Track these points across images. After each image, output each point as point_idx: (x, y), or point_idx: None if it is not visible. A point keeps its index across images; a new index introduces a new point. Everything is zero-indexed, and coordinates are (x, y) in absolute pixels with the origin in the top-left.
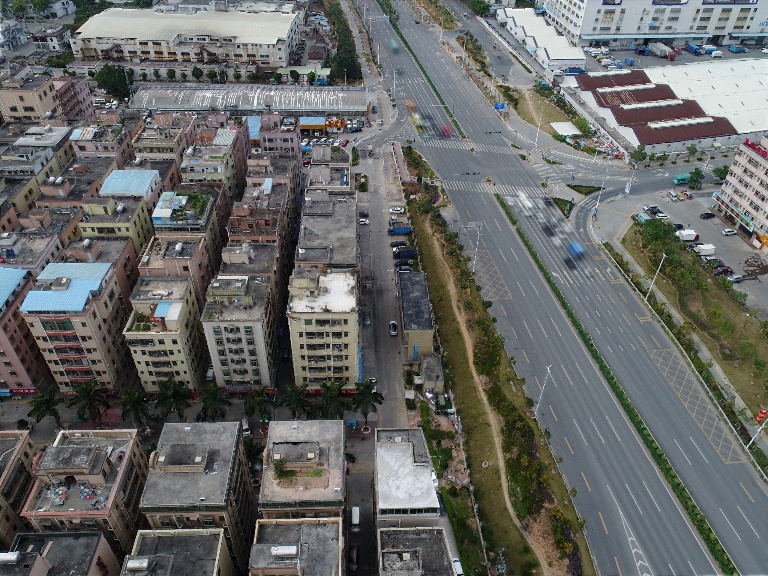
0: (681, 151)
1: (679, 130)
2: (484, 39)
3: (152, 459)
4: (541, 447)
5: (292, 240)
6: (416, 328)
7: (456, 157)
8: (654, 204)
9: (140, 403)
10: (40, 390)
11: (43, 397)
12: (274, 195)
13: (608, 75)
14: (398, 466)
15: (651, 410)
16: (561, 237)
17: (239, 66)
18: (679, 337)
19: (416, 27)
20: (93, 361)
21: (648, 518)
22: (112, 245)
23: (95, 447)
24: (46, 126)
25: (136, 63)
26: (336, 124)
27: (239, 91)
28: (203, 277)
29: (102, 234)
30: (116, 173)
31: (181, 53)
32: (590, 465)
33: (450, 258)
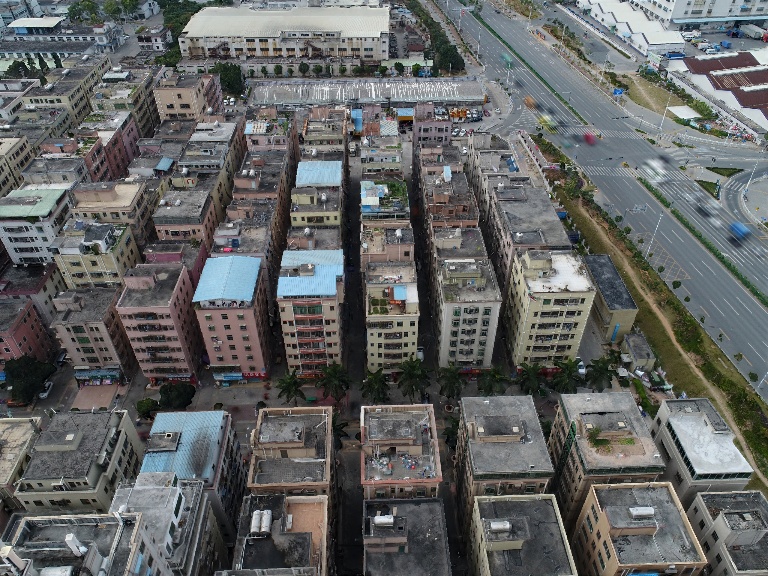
0: None
1: None
2: (571, 26)
3: (471, 430)
4: None
5: None
6: (620, 308)
7: (585, 143)
8: None
9: (383, 383)
10: (266, 374)
11: (292, 379)
12: (455, 182)
13: (716, 58)
14: (697, 434)
15: None
16: (718, 218)
17: (344, 60)
18: None
19: (498, 17)
20: (329, 344)
21: None
22: (324, 233)
23: (414, 420)
24: None
25: (243, 60)
26: (458, 114)
27: (354, 84)
28: None
29: (311, 223)
30: (303, 165)
31: (286, 49)
32: None
33: (617, 241)
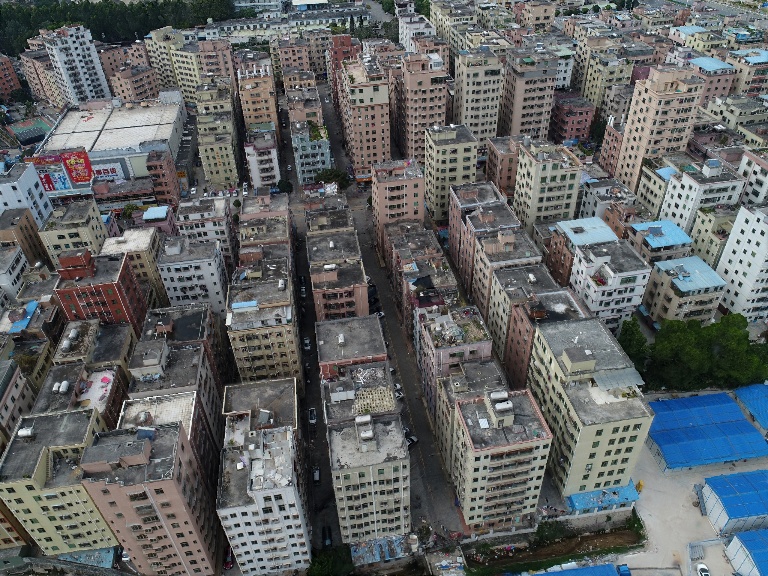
0: None
1: None
2: None
3: None
4: None
5: None
6: None
7: None
8: None
9: None
10: None
11: None
12: None
13: None
14: None
15: None
16: None
17: None
18: None
19: None
20: None
21: None
22: None
23: None
24: None
25: None
26: None
27: None
28: None
29: None
30: None
31: (514, 2)
32: None
33: None
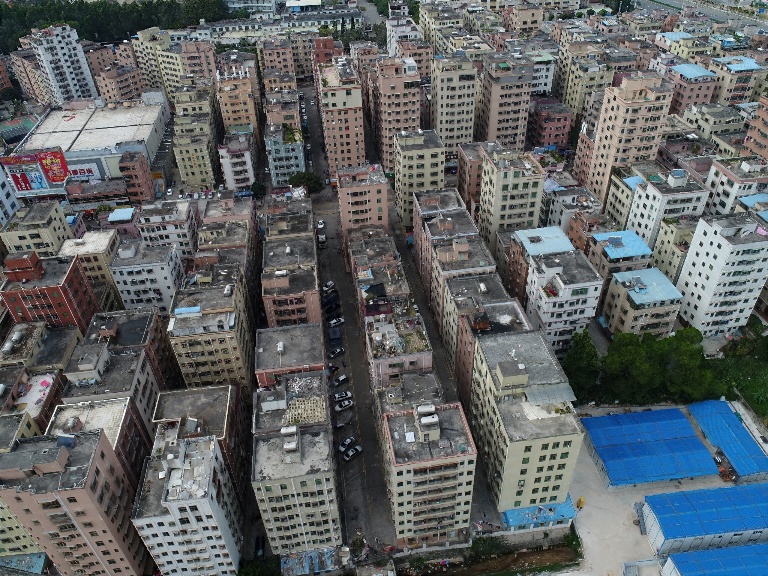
0: None
1: None
2: None
3: None
4: None
5: None
6: None
7: None
8: None
9: None
10: None
11: None
12: None
13: None
14: None
15: None
16: None
17: None
18: None
19: None
20: None
21: None
22: None
23: None
24: None
25: None
26: None
27: (578, 21)
28: None
29: None
30: None
31: None
32: None
33: None
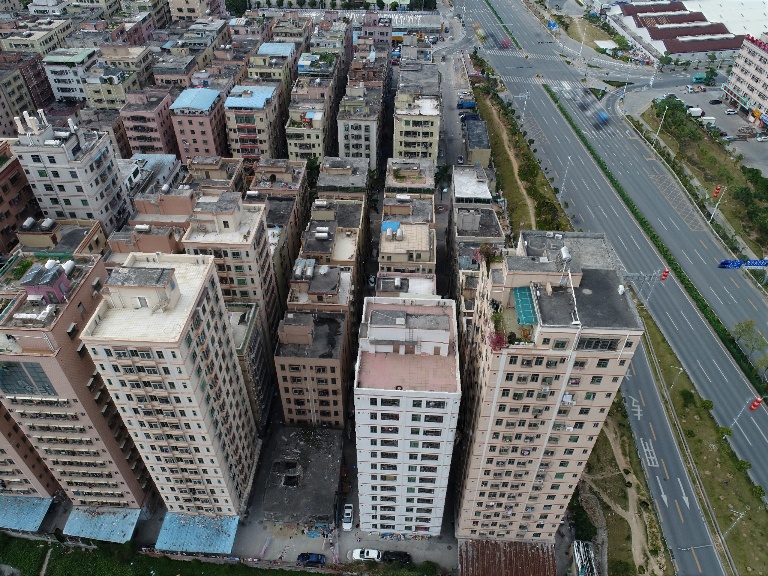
0: (704, 61)
1: (703, 43)
2: None
3: (321, 166)
4: (562, 216)
5: (388, 99)
6: (478, 148)
7: (513, 61)
8: (672, 93)
9: None
10: None
11: None
12: (377, 63)
13: (649, 5)
14: (467, 182)
15: (644, 204)
16: (593, 112)
17: None
18: (674, 168)
19: None
20: (262, 151)
21: (631, 251)
22: (270, 84)
23: None
24: (207, 19)
25: None
26: None
27: None
28: (331, 108)
29: (262, 78)
30: (266, 44)
31: None
32: (595, 227)
33: (504, 120)
